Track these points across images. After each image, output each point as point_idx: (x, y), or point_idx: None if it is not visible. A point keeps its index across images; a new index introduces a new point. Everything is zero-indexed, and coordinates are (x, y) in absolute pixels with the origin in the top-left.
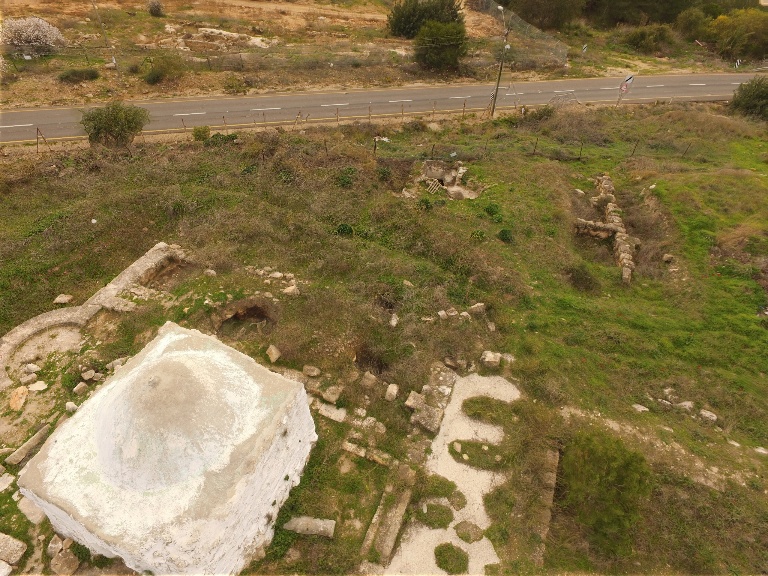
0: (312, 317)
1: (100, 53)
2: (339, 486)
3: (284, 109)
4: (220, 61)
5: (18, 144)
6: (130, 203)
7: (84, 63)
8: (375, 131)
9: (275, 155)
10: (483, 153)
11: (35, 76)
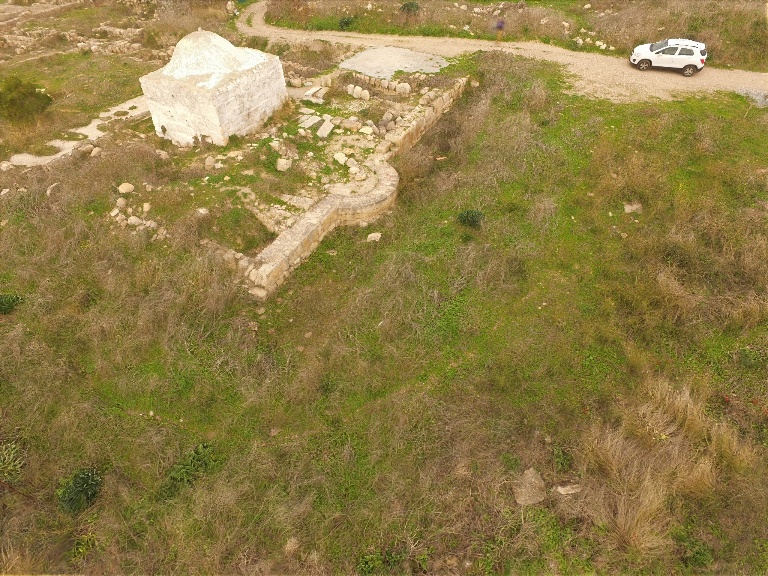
0: None
1: None
2: None
3: None
4: None
5: None
6: None
7: None
8: None
9: None
10: None
11: None
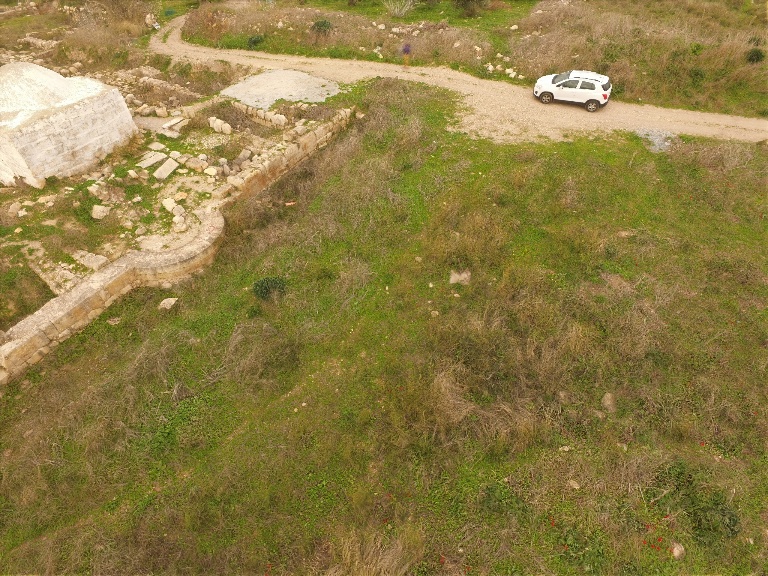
0: None
1: None
2: None
3: None
4: None
5: None
6: None
7: None
8: None
9: None
10: None
11: None
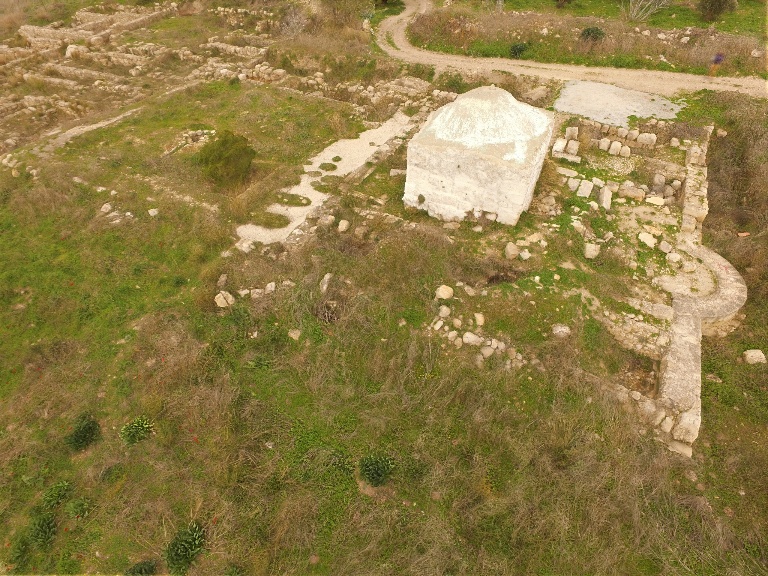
0: None
1: None
2: (388, 188)
3: None
4: None
5: None
6: None
7: None
8: None
9: None
10: None
11: None
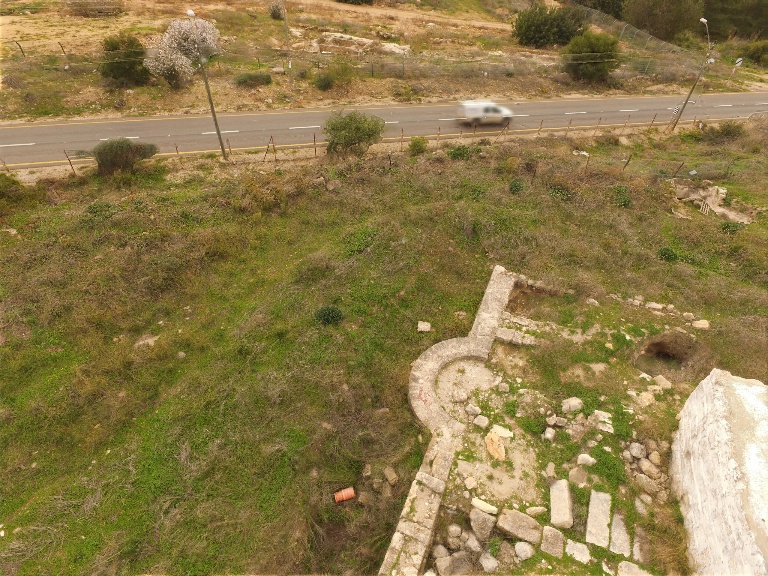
0: (751, 357)
1: (347, 60)
2: None
3: (471, 119)
4: (379, 67)
5: (240, 152)
6: (427, 220)
7: (247, 67)
8: (574, 144)
9: (539, 171)
10: (726, 172)
11: (210, 79)
